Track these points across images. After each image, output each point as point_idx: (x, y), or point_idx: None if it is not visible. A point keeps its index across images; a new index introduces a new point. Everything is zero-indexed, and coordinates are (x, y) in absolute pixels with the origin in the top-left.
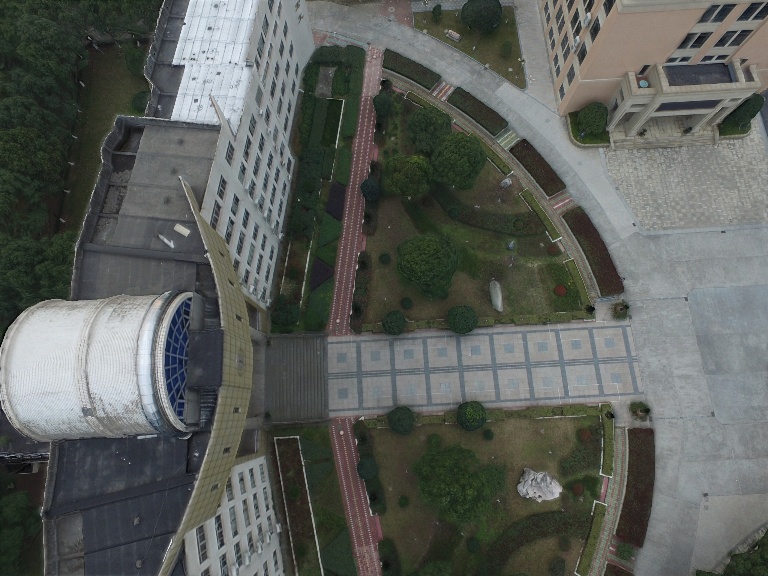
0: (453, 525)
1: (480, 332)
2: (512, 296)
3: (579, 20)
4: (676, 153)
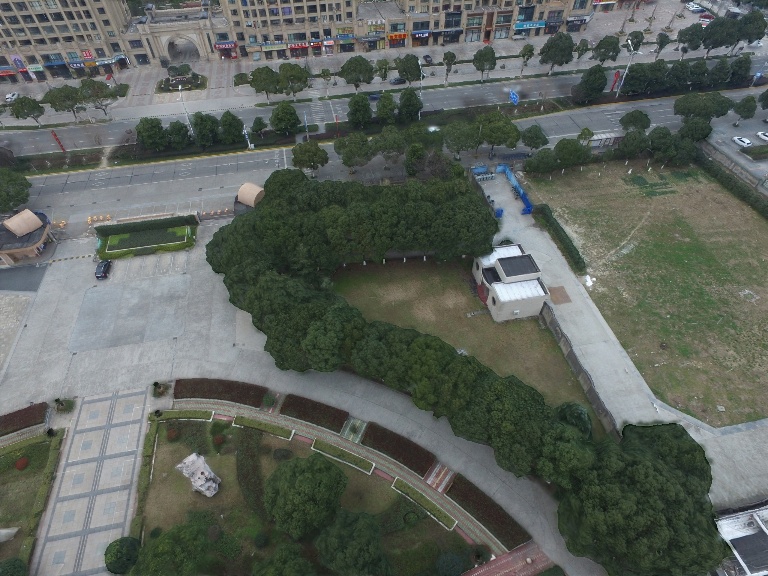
0: (242, 566)
1: (39, 554)
2: (8, 517)
3: None
4: None
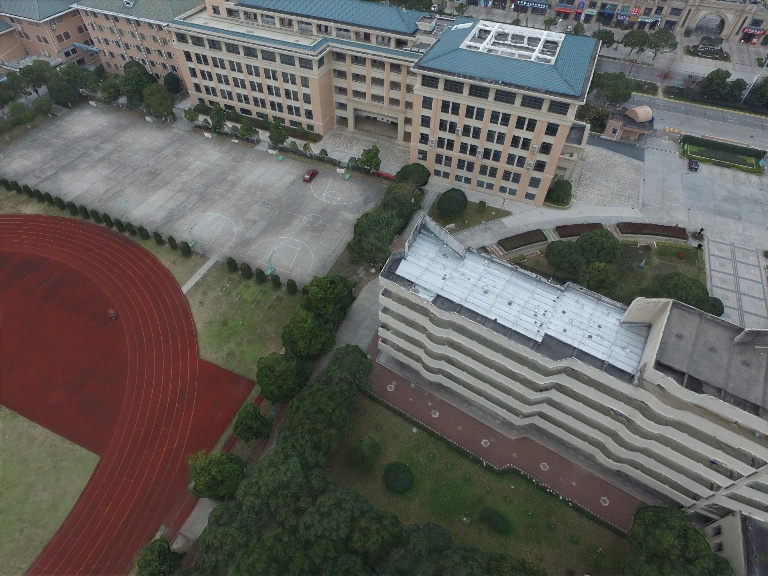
0: None
1: None
2: None
3: (518, 156)
4: (585, 175)
